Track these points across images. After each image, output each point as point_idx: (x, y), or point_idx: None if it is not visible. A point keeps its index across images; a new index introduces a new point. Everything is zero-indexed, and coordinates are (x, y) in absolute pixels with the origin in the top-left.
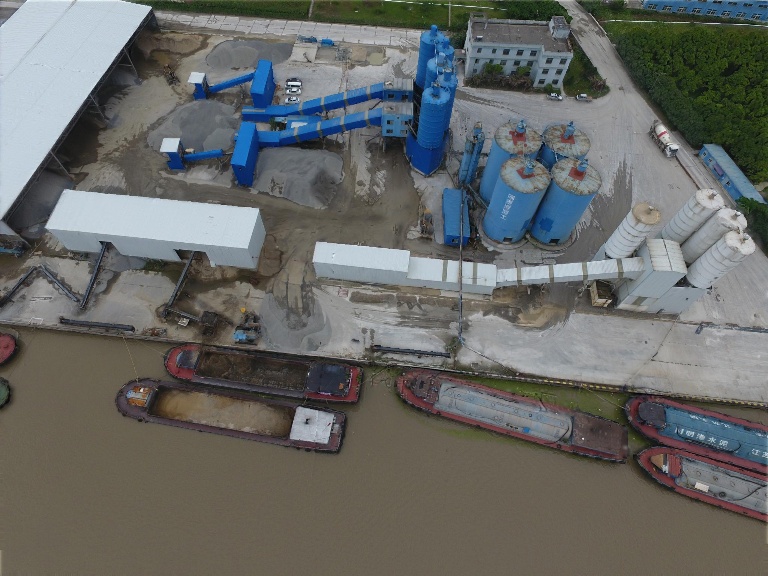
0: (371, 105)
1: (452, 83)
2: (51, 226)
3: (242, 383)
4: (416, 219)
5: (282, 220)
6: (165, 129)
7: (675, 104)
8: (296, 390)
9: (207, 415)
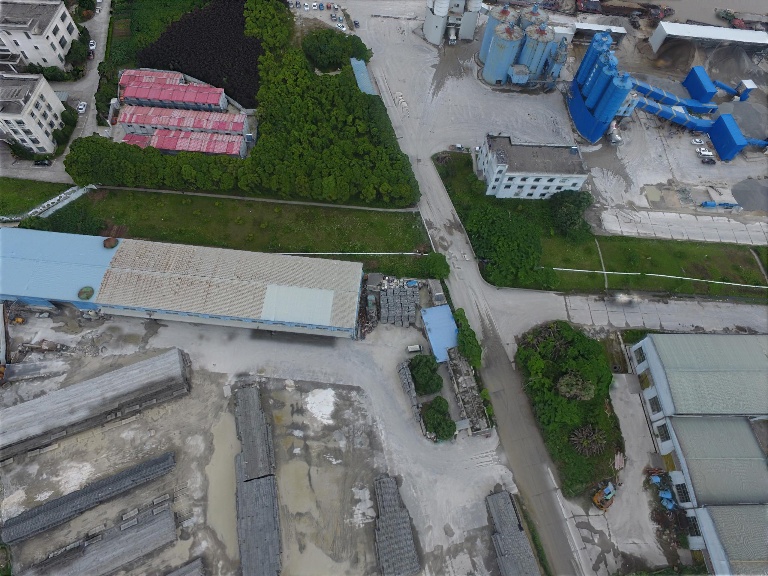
0: (635, 142)
1: (597, 43)
2: (763, 32)
3: (627, 7)
4: (572, 66)
5: (650, 67)
6: (767, 109)
7: (388, 122)
8: (603, 4)
9: (634, 3)
